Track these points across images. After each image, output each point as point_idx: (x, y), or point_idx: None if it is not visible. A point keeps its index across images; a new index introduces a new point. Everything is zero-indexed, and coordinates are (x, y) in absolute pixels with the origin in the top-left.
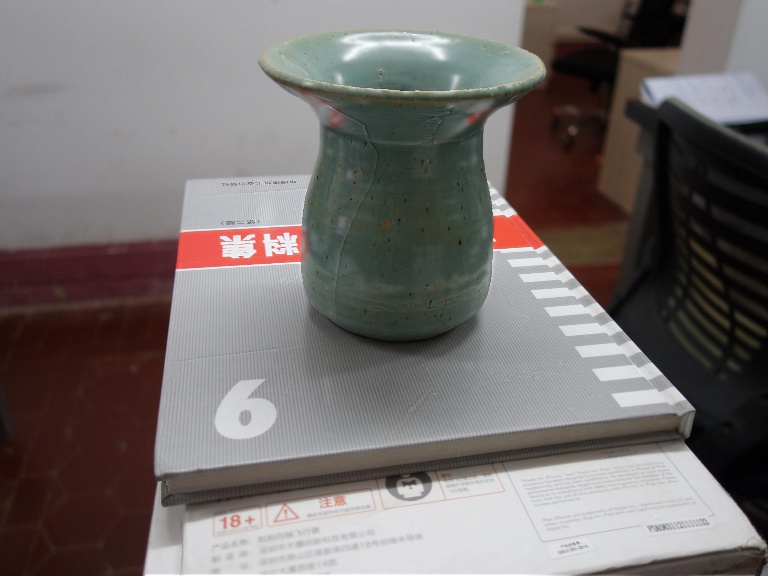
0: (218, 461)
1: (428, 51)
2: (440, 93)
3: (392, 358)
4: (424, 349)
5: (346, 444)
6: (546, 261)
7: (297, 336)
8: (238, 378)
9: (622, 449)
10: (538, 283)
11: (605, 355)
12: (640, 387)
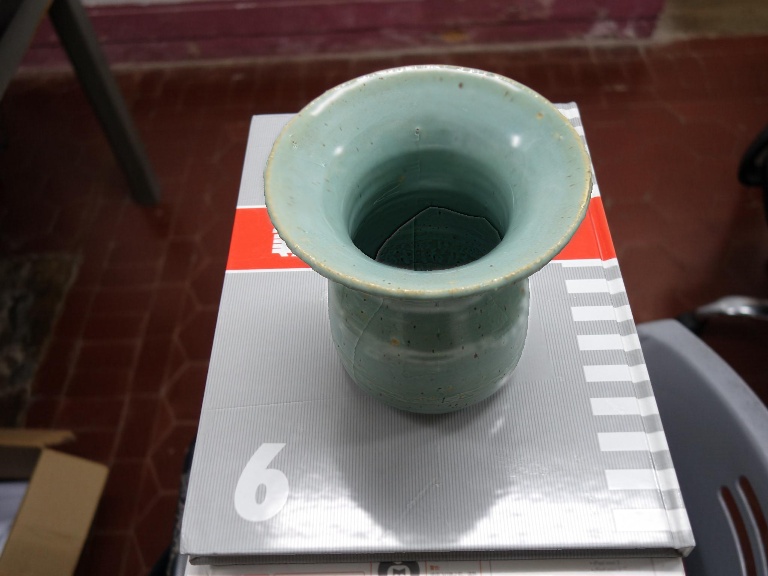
0: (231, 546)
1: (476, 104)
2: (432, 293)
3: (408, 428)
4: (442, 419)
5: (342, 542)
6: (610, 283)
7: (324, 385)
8: (262, 440)
9: (613, 561)
10: (589, 324)
11: (626, 450)
12: (648, 504)
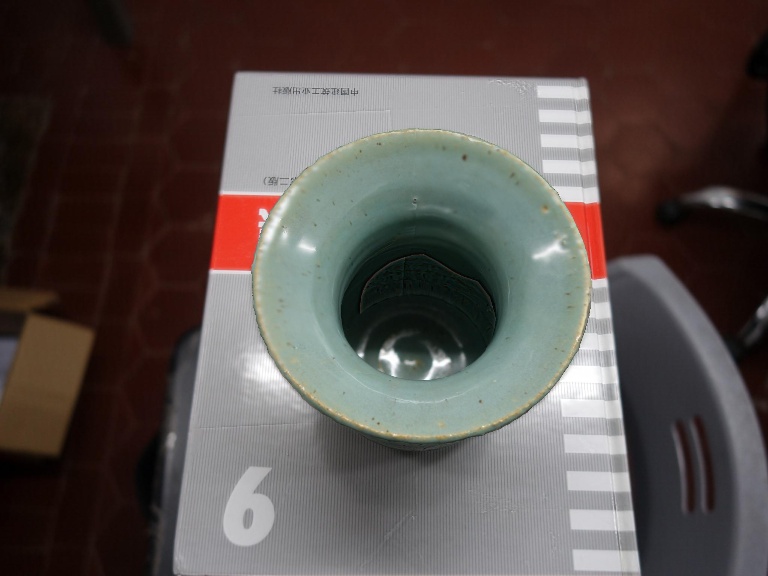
0: (221, 570)
1: (479, 181)
2: (420, 438)
3: (388, 458)
4: None
5: (323, 570)
6: (597, 306)
7: (309, 407)
8: (249, 463)
9: None
10: None
11: (592, 490)
12: (604, 545)
